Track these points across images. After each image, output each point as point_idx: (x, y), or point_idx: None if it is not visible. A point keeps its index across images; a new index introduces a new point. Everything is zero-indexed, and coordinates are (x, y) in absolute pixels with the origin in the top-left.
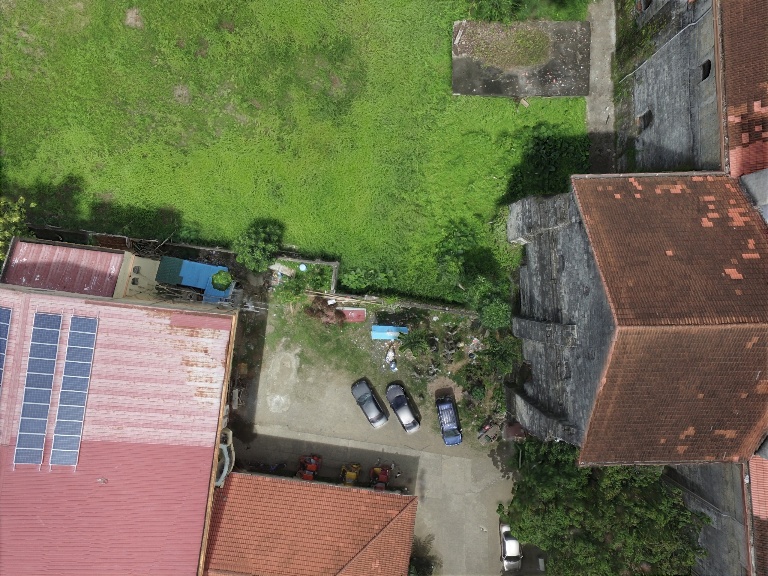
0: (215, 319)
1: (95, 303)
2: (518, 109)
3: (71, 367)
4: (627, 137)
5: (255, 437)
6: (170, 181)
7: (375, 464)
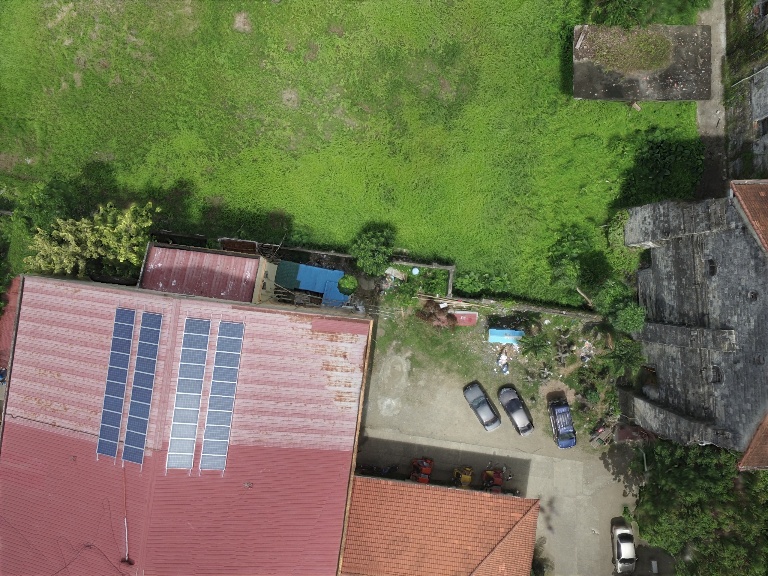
0: (353, 324)
1: (241, 308)
2: (630, 113)
3: (219, 372)
4: (743, 141)
5: (366, 440)
6: (281, 185)
7: (487, 467)
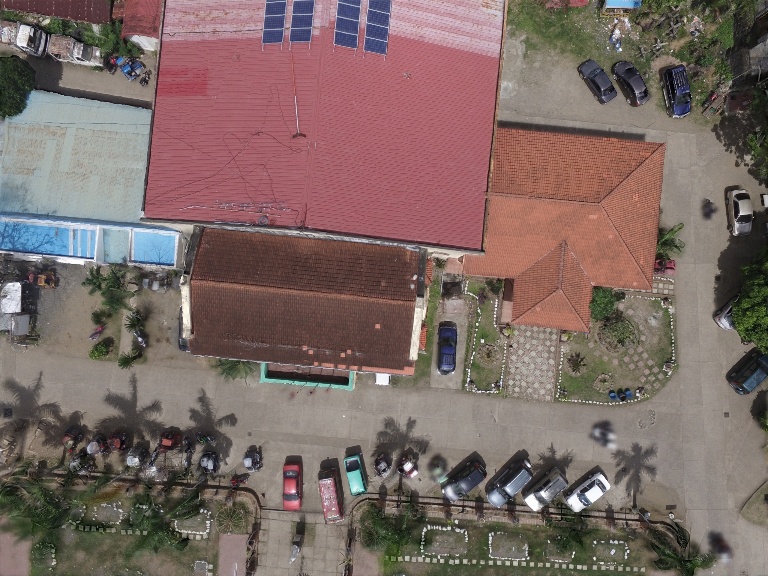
0: None
1: None
2: None
3: None
4: None
5: None
6: None
7: None
